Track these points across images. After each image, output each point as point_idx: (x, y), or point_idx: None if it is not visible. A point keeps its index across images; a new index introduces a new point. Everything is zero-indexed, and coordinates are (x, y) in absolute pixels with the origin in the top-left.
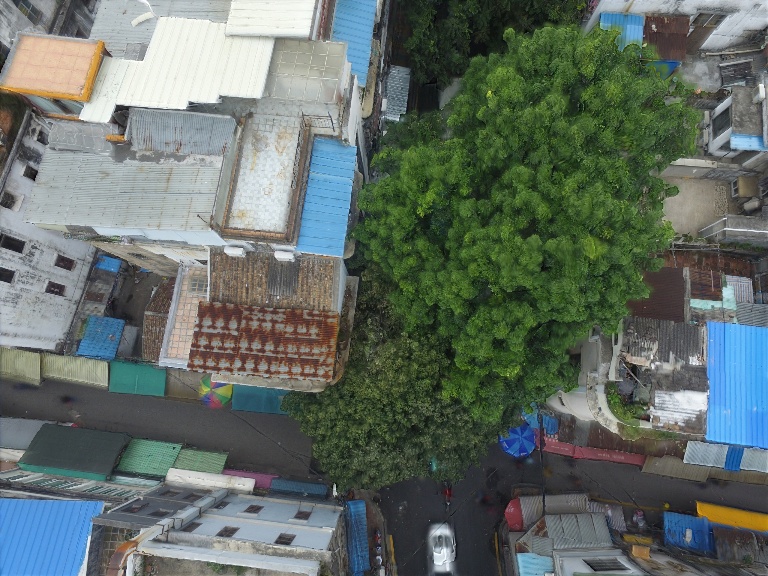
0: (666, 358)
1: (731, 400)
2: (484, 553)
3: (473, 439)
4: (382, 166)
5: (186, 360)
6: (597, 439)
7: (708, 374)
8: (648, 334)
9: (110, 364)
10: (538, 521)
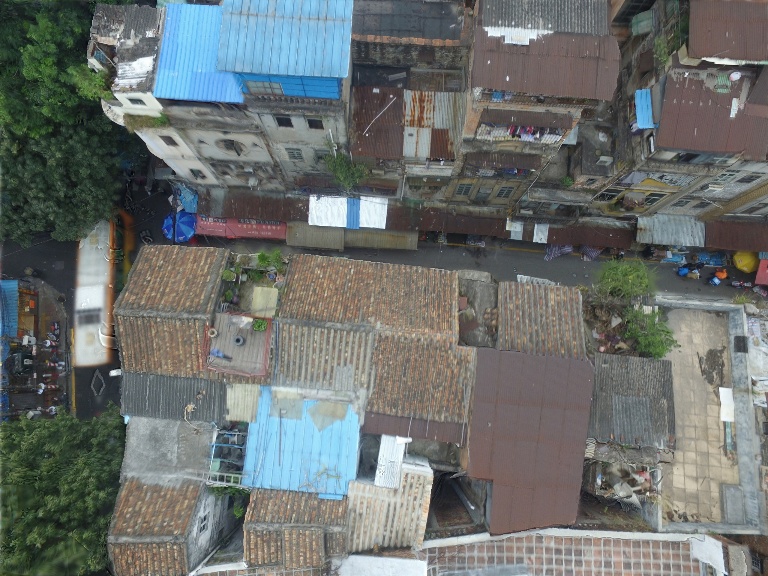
0: (129, 35)
1: (179, 65)
2: None
3: (10, 149)
4: None
5: None
6: (231, 209)
7: (162, 45)
8: (116, 17)
9: None
10: None
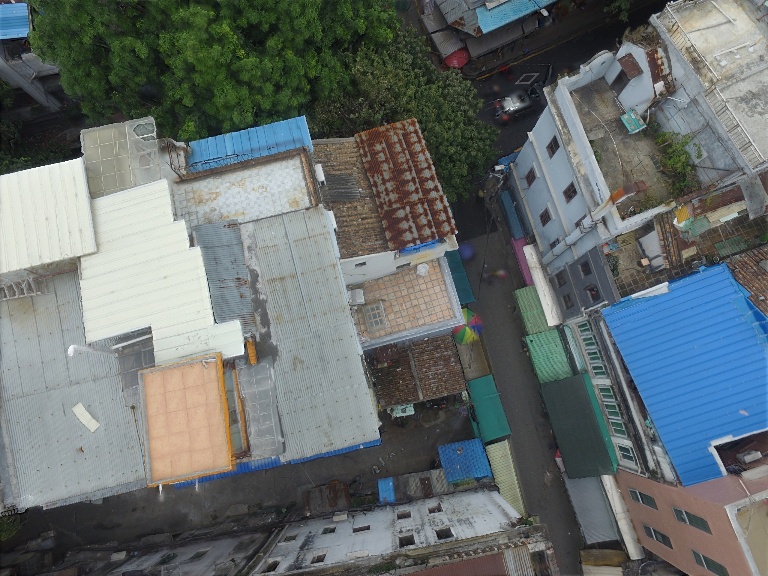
0: None
1: None
2: (495, 83)
3: None
4: (202, 133)
5: (450, 296)
6: None
7: None
8: None
9: (486, 443)
10: (455, 28)
